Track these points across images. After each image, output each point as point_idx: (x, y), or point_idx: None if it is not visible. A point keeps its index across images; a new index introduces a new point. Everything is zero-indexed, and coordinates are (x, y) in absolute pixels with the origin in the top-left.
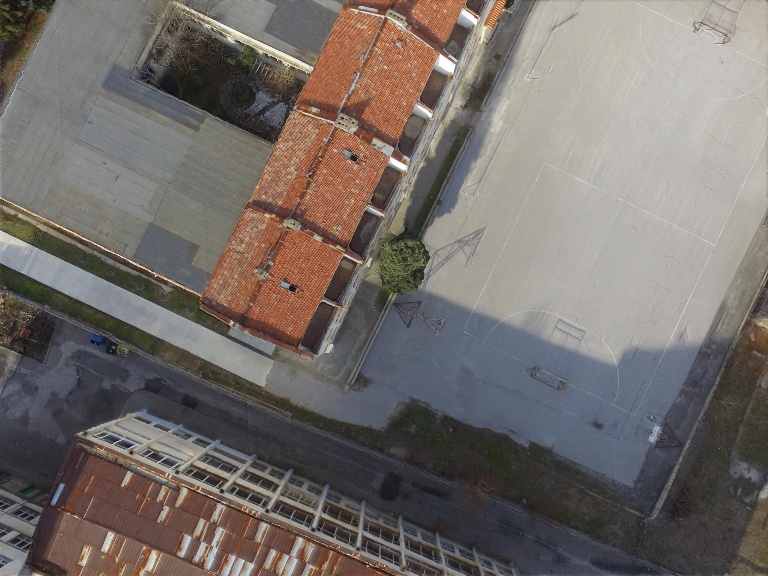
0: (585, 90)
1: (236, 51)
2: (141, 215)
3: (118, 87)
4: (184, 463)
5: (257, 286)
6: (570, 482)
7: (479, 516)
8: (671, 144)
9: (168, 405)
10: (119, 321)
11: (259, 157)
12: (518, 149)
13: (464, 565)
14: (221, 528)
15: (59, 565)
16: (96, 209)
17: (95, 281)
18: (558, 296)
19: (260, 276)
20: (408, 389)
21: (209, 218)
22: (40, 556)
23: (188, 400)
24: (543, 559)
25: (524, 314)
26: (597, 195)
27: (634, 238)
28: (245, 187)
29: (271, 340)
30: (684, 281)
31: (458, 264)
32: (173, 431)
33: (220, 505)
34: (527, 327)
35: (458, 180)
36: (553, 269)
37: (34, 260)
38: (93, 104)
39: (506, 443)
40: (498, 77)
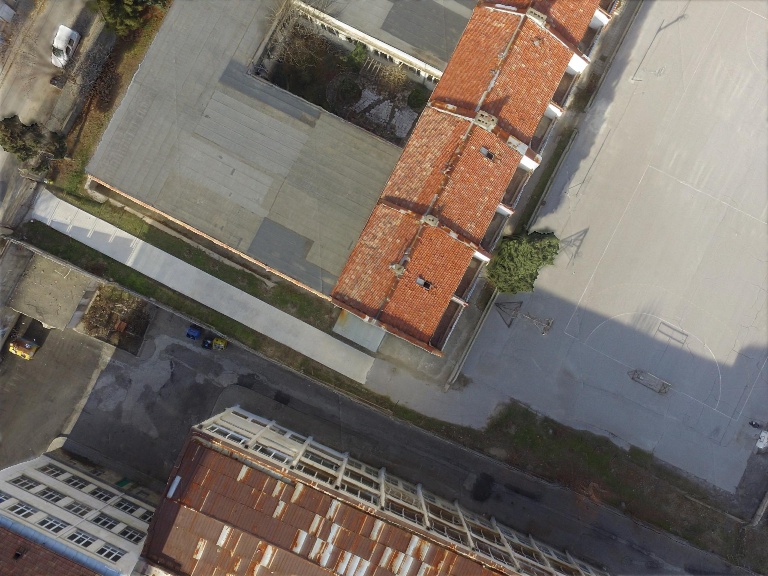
0: (690, 93)
1: (342, 48)
2: (256, 209)
3: (234, 82)
4: (293, 458)
5: (393, 282)
6: (670, 487)
7: (572, 519)
8: None
9: (261, 400)
10: (222, 315)
11: (374, 154)
12: (621, 151)
13: (565, 568)
14: (337, 524)
15: (174, 558)
16: (211, 203)
17: (199, 275)
18: (660, 299)
19: (398, 272)
20: (508, 389)
21: (324, 214)
22: (155, 548)
23: (281, 396)
24: (636, 564)
25: (626, 316)
26: (701, 198)
27: (738, 242)
28: (360, 183)
29: (405, 336)
30: None
31: (560, 265)
32: (270, 426)
33: (336, 501)
34: (629, 329)
35: (561, 181)
36: (656, 272)
37: (139, 253)
38: (210, 98)
39: (606, 446)
40: (604, 78)
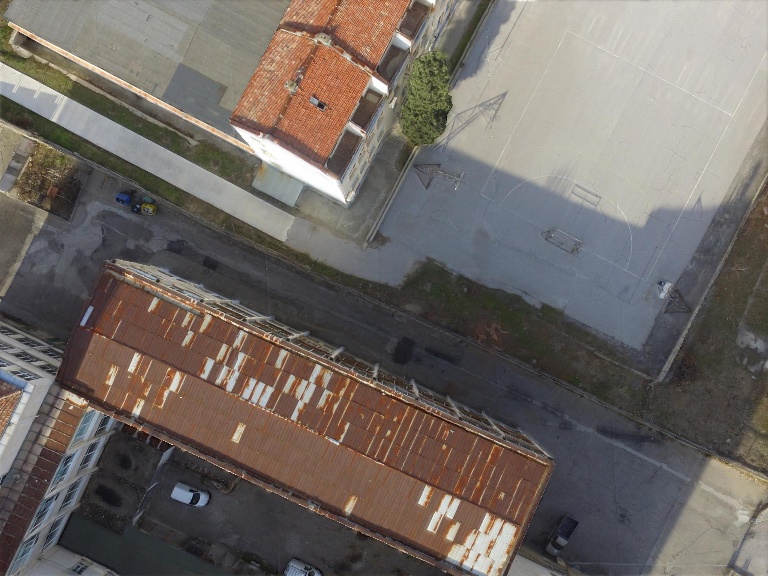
0: None
1: None
2: (171, 55)
3: None
4: None
5: (287, 99)
6: (580, 344)
7: (489, 382)
8: (694, 15)
9: (190, 266)
10: (145, 172)
11: (287, 1)
12: (541, 16)
13: (474, 416)
14: (243, 353)
15: (87, 384)
16: (127, 48)
17: (123, 132)
18: (575, 162)
19: (290, 88)
20: (425, 249)
21: (237, 60)
22: (69, 375)
23: (209, 262)
24: (550, 425)
25: (541, 179)
26: (618, 63)
27: (653, 107)
28: (273, 30)
29: (299, 154)
30: (701, 151)
31: (478, 128)
32: (195, 285)
33: (243, 332)
34: (544, 192)
35: (481, 45)
36: (571, 135)
37: (64, 109)
38: None
39: (519, 304)
40: None
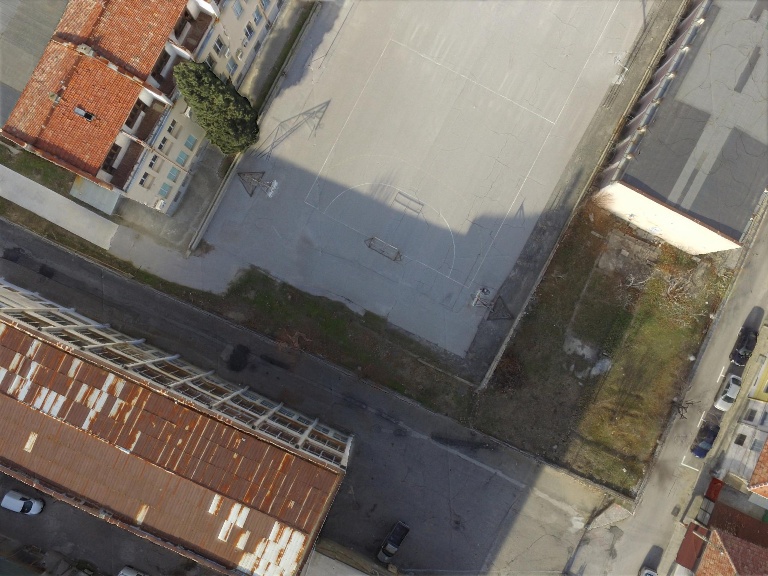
0: None
1: None
2: None
3: None
4: None
5: (50, 110)
6: (404, 351)
7: (324, 389)
8: (516, 23)
9: (25, 274)
10: None
11: None
12: (365, 24)
13: (293, 424)
14: (36, 362)
15: None
16: None
17: None
18: (398, 170)
19: (51, 98)
20: (249, 256)
21: None
22: None
23: (45, 270)
24: (385, 432)
25: (364, 186)
26: (440, 71)
27: (475, 115)
28: None
29: (65, 164)
30: (523, 158)
31: (302, 136)
32: (23, 293)
33: (37, 341)
34: (367, 199)
35: (304, 53)
36: (394, 143)
37: None
38: None
39: (342, 311)
40: None
